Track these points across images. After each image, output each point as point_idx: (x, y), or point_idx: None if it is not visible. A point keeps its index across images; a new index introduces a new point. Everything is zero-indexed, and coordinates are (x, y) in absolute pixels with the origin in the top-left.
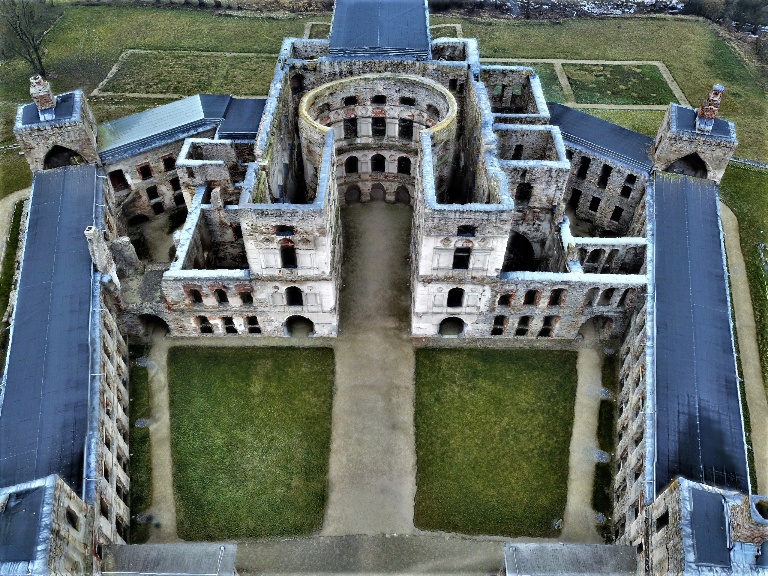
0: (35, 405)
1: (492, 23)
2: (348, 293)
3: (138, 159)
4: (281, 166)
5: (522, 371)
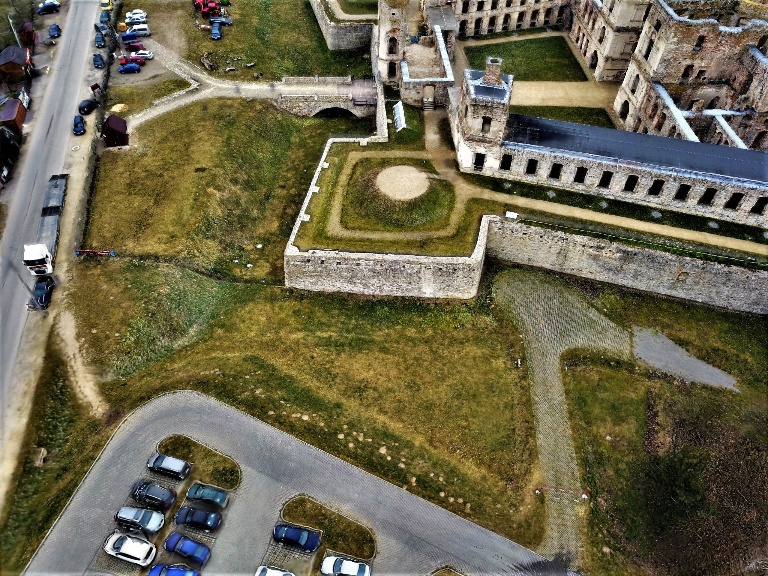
0: None
1: None
2: None
3: None
4: None
5: None
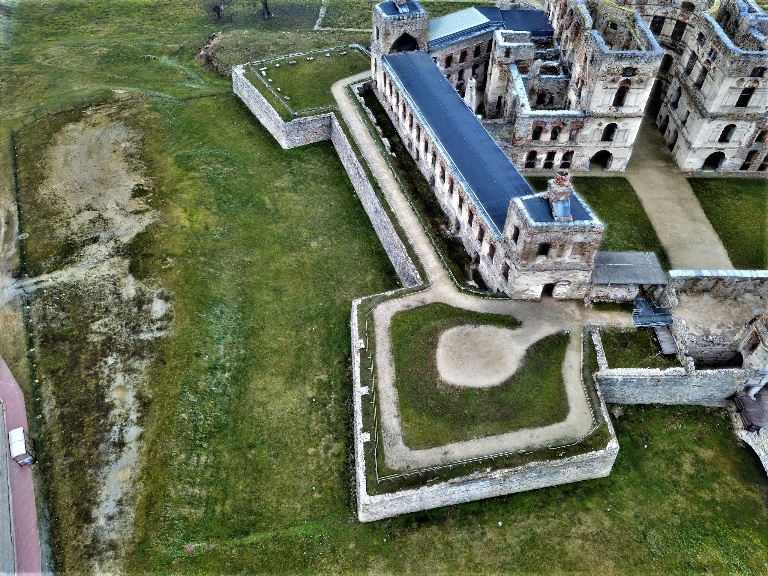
0: (489, 178)
1: None
2: None
3: (448, 50)
4: None
5: None
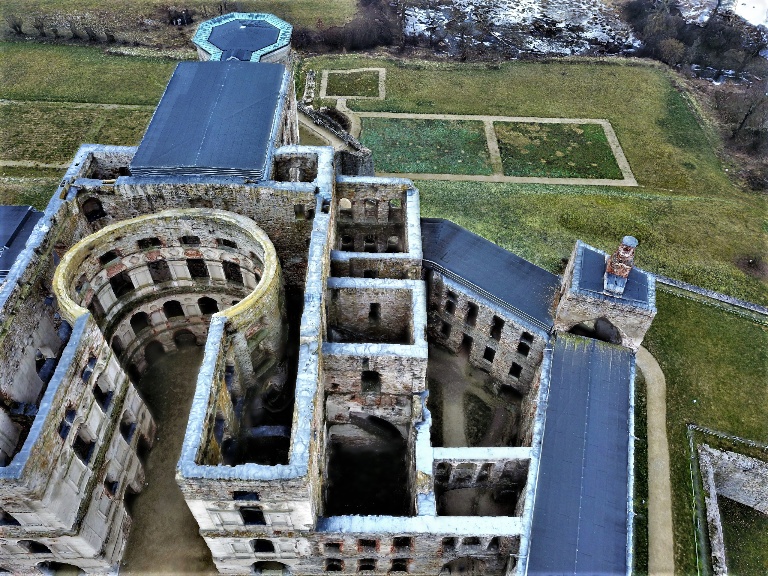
0: None
1: (421, 67)
2: (149, 497)
3: None
4: (48, 338)
5: None
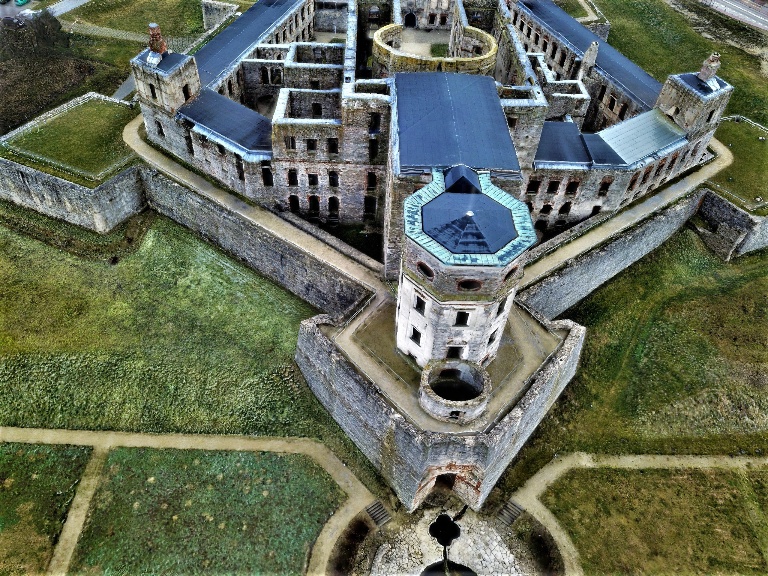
0: None
1: None
2: None
3: None
4: None
5: None
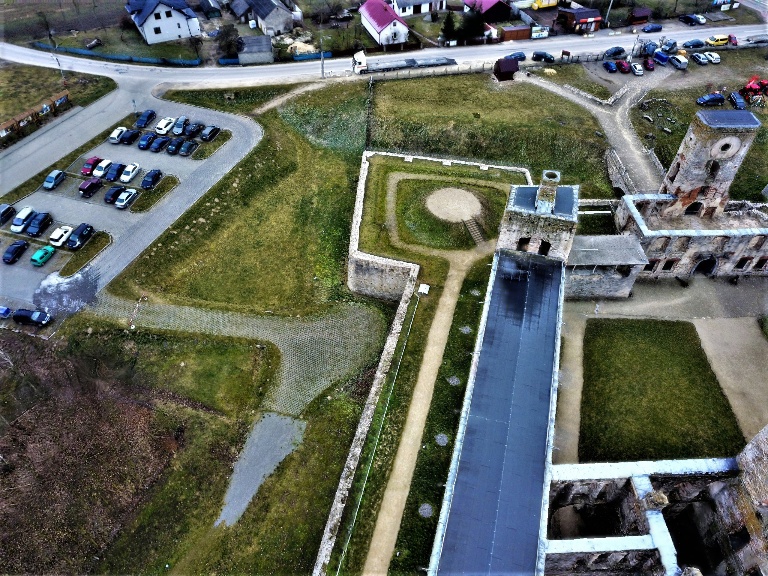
0: None
1: None
2: None
3: None
4: None
5: (639, 457)
